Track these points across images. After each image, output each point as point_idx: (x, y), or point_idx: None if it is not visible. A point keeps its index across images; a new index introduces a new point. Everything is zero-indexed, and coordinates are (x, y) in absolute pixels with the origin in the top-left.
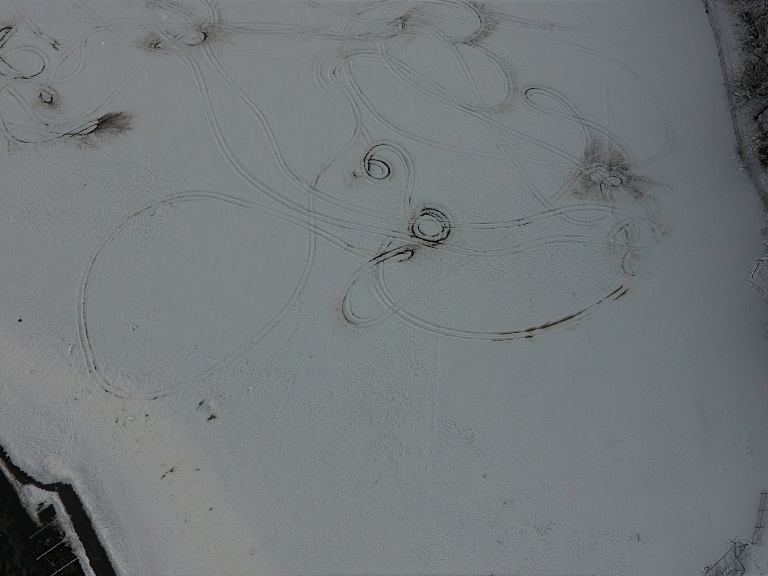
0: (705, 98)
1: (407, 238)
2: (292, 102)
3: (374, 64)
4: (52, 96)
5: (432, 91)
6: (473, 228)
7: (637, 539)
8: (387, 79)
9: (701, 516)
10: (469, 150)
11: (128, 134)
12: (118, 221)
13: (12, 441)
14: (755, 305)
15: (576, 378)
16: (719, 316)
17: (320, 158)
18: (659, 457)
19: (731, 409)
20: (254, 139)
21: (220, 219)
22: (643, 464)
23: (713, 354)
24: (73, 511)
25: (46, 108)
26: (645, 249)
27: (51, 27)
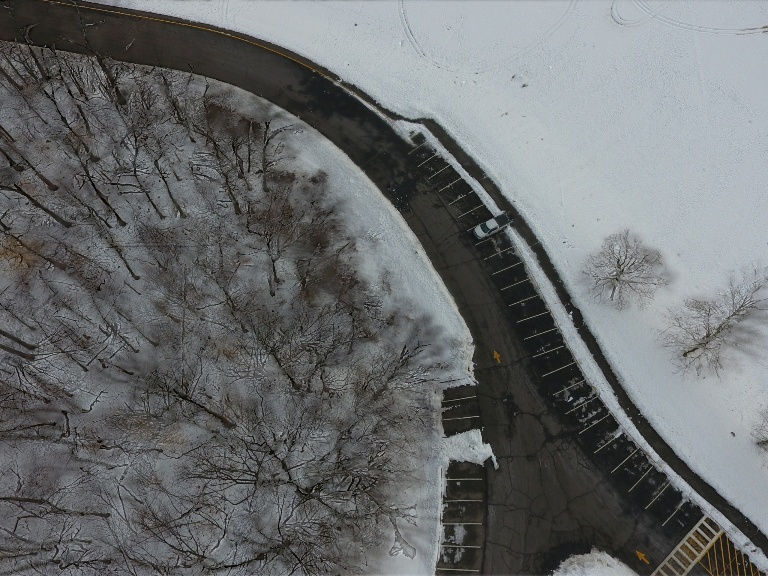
0: None
1: None
2: None
3: None
4: None
5: None
6: None
7: None
8: None
9: None
10: None
11: None
12: None
13: (379, 93)
14: None
15: None
16: None
17: None
18: None
19: None
20: None
21: None
22: None
23: None
24: (439, 135)
25: None
26: None
27: None
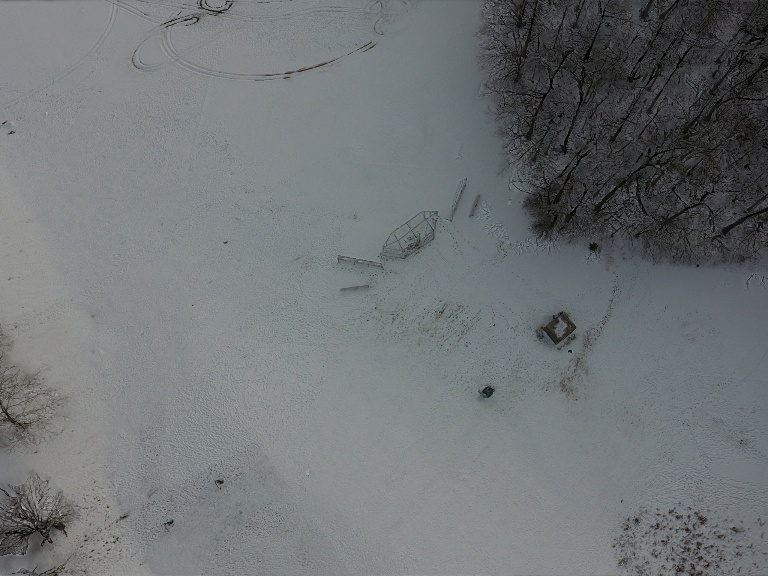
0: None
1: (195, 9)
2: None
3: None
4: None
5: None
6: (252, 2)
7: (354, 218)
8: None
9: (410, 202)
10: None
11: None
12: None
13: None
14: None
15: (321, 106)
16: (450, 62)
17: None
18: (382, 161)
19: (449, 127)
20: None
21: None
22: (368, 166)
23: (440, 89)
24: None
25: None
26: (395, 16)
27: None
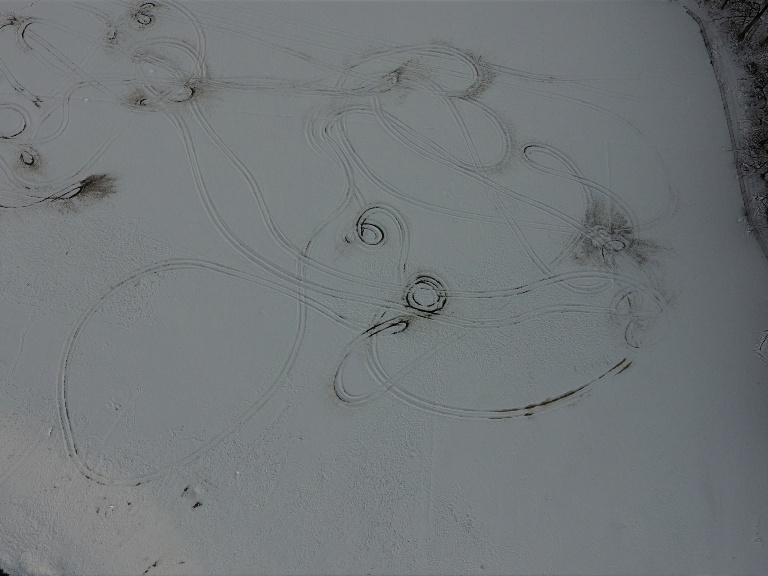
0: (710, 155)
1: (401, 308)
2: (282, 162)
3: (367, 121)
4: (33, 157)
5: (427, 149)
6: (470, 297)
7: None
8: (381, 137)
9: None
10: (466, 213)
11: (112, 198)
12: (101, 292)
13: None
14: (764, 380)
15: (577, 459)
16: (726, 391)
17: (311, 222)
18: (664, 545)
19: (739, 492)
20: (243, 202)
21: (207, 289)
22: (648, 553)
23: (720, 432)
24: None
25: (27, 170)
26: (649, 319)
27: (33, 83)
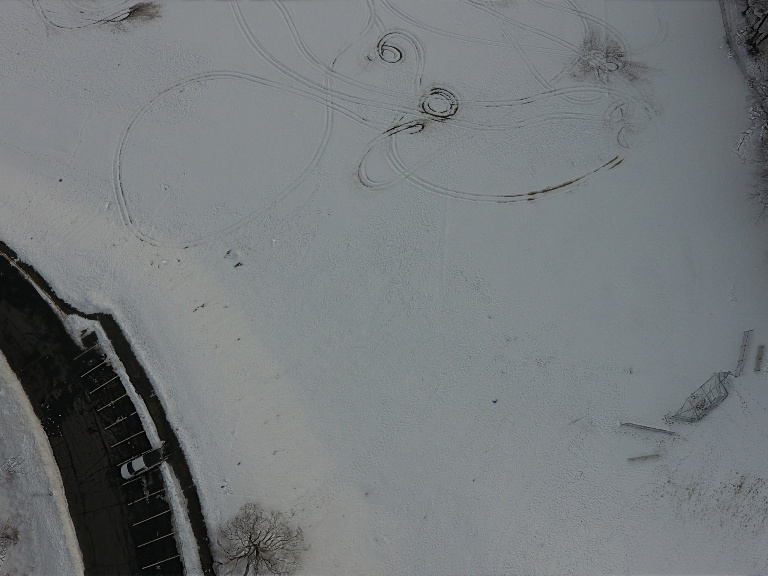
0: None
1: (418, 113)
2: None
3: None
4: None
5: None
6: (479, 106)
7: (630, 372)
8: None
9: (689, 353)
10: (475, 38)
11: (158, 21)
12: (150, 96)
13: (57, 278)
14: (740, 172)
15: (574, 235)
16: (707, 183)
17: (337, 44)
18: (650, 303)
19: (717, 263)
20: (275, 27)
21: (244, 95)
22: (636, 308)
23: (701, 215)
24: (114, 337)
25: None
26: (639, 125)
27: None
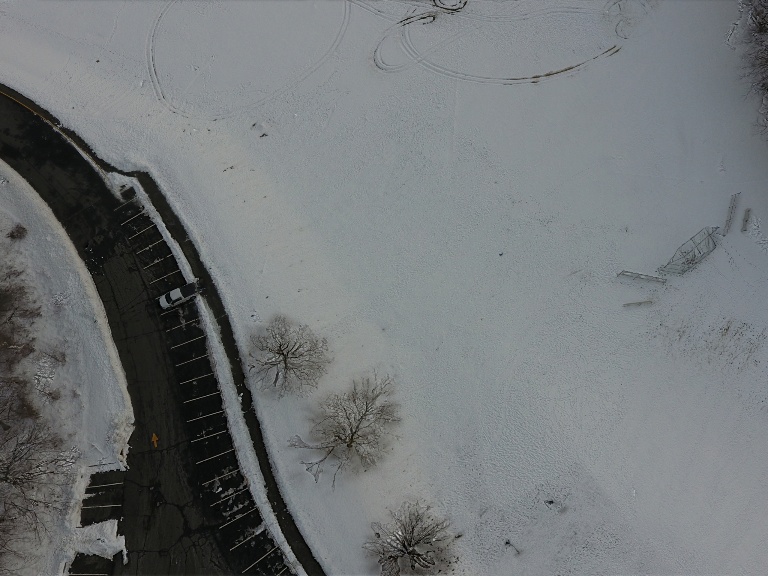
0: None
1: (429, 7)
2: None
3: None
4: None
5: None
6: (487, 0)
7: (626, 231)
8: None
9: (680, 215)
10: None
11: None
12: None
13: (97, 141)
14: (730, 58)
15: (575, 113)
16: (699, 69)
17: None
18: (645, 172)
19: (708, 138)
20: None
21: None
22: (632, 176)
23: (693, 97)
24: (150, 191)
25: None
26: (636, 18)
27: None
